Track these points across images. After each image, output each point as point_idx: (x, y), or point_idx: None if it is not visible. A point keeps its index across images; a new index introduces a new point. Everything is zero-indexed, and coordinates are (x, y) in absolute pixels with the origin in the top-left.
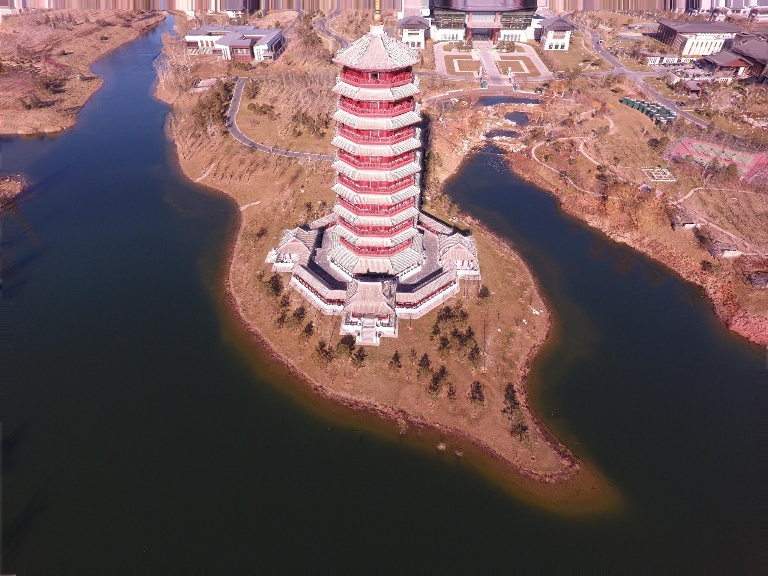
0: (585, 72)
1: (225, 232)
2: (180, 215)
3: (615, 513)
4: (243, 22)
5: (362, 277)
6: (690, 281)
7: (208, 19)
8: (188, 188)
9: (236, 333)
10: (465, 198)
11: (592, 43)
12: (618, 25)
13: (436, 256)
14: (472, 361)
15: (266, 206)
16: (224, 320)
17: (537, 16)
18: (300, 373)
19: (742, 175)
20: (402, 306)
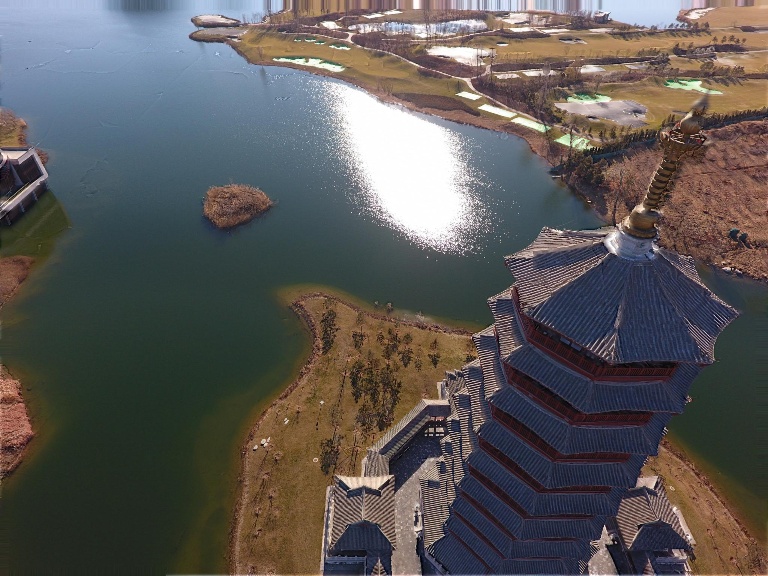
0: None
1: None
2: None
3: None
4: None
5: None
6: None
7: None
8: None
9: None
10: None
11: None
12: None
13: (397, 533)
14: None
15: None
16: None
17: None
18: None
19: None
20: None
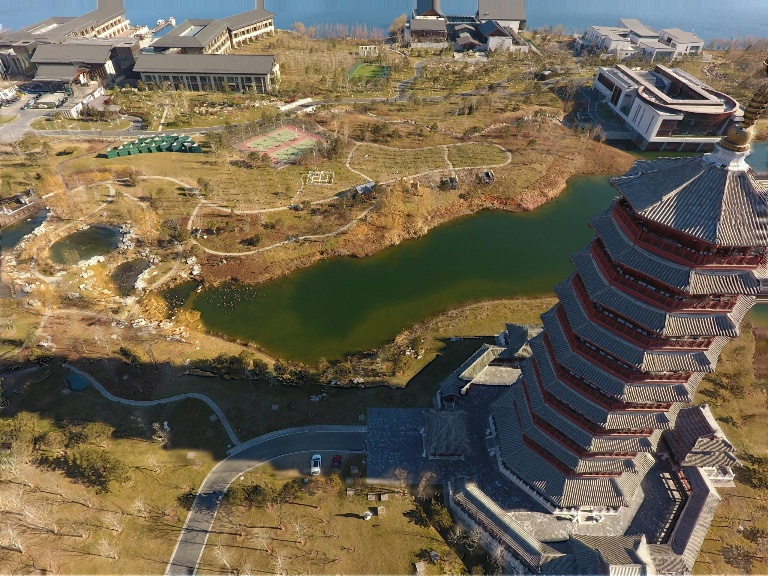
0: None
1: None
2: None
3: None
4: None
5: None
6: (477, 212)
7: None
8: None
9: None
10: (331, 342)
11: None
12: None
13: None
14: None
15: None
16: None
17: None
18: None
19: None
20: None
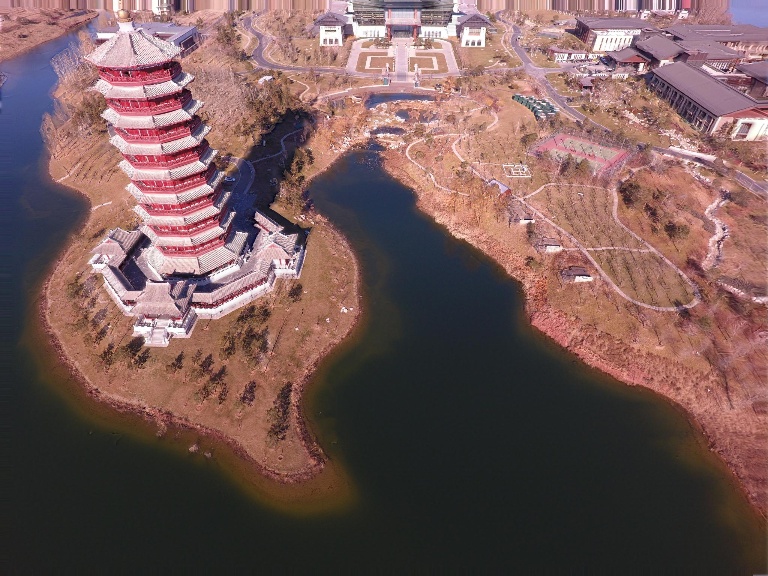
0: (492, 68)
1: (67, 233)
2: (28, 216)
3: (344, 511)
4: (166, 19)
5: (173, 277)
6: (513, 277)
7: (133, 16)
8: (48, 188)
9: (34, 336)
10: (326, 196)
11: (508, 39)
12: (544, 21)
13: None
14: (255, 361)
15: (115, 206)
16: (28, 323)
17: (459, 12)
18: (81, 376)
19: (594, 170)
20: (203, 306)
